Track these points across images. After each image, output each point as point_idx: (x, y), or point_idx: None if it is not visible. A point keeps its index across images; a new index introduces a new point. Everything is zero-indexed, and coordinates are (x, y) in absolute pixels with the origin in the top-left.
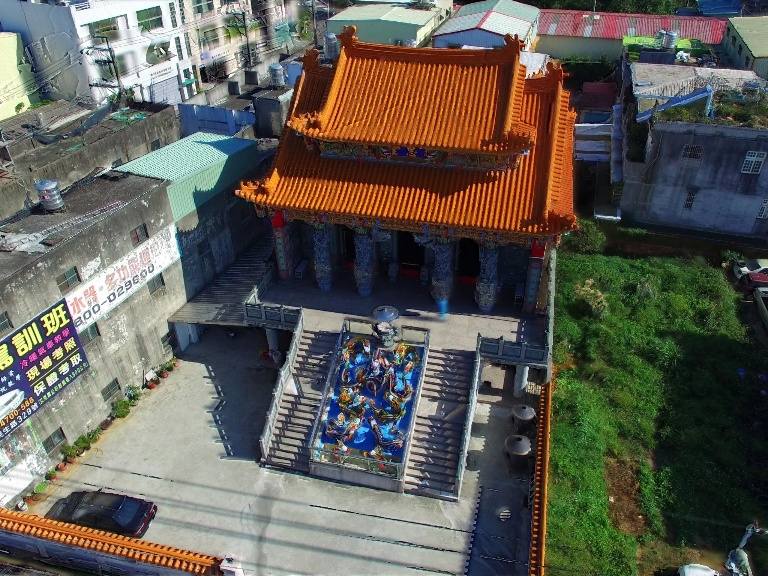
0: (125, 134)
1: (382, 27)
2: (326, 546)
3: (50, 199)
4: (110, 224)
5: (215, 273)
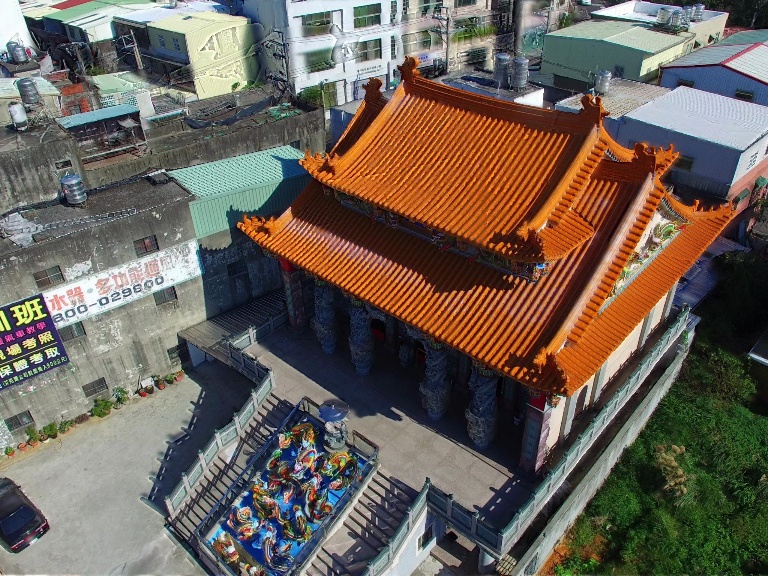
0: (261, 131)
1: (603, 49)
2: None
3: (70, 193)
4: (108, 230)
5: (251, 296)
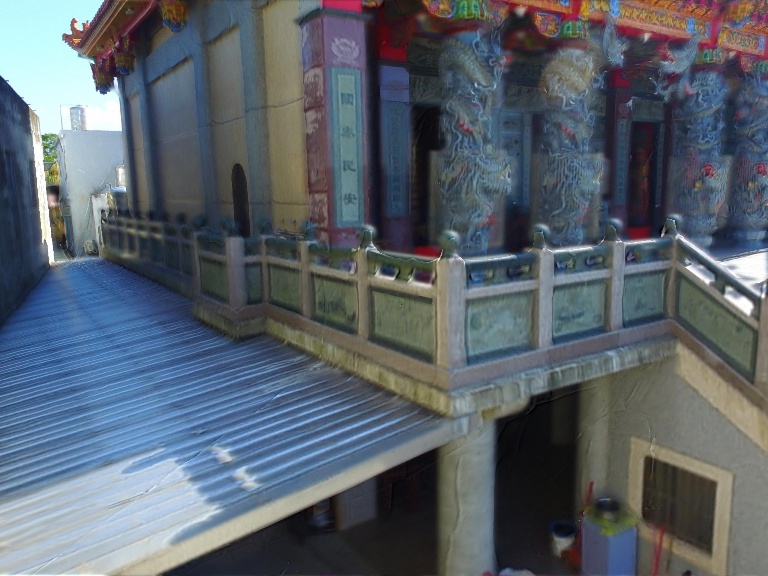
0: None
1: None
2: None
3: None
4: None
5: None
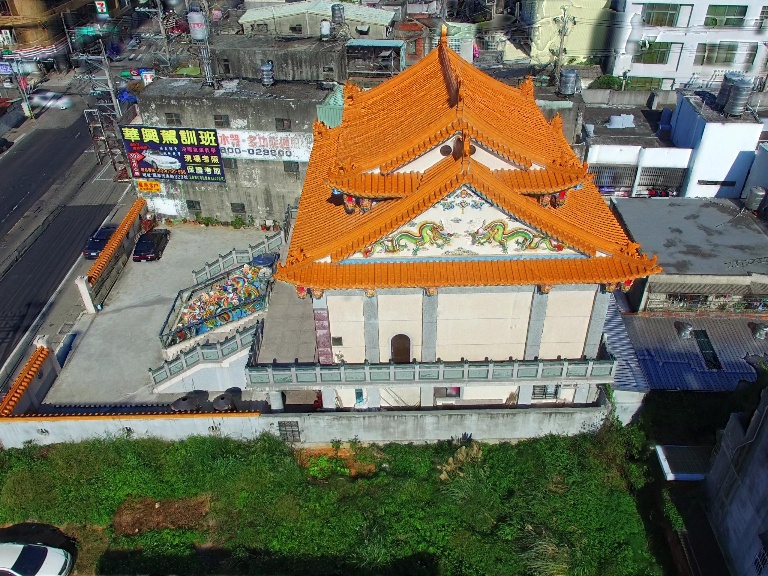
0: None
1: None
2: (123, 334)
3: None
4: (261, 104)
5: None
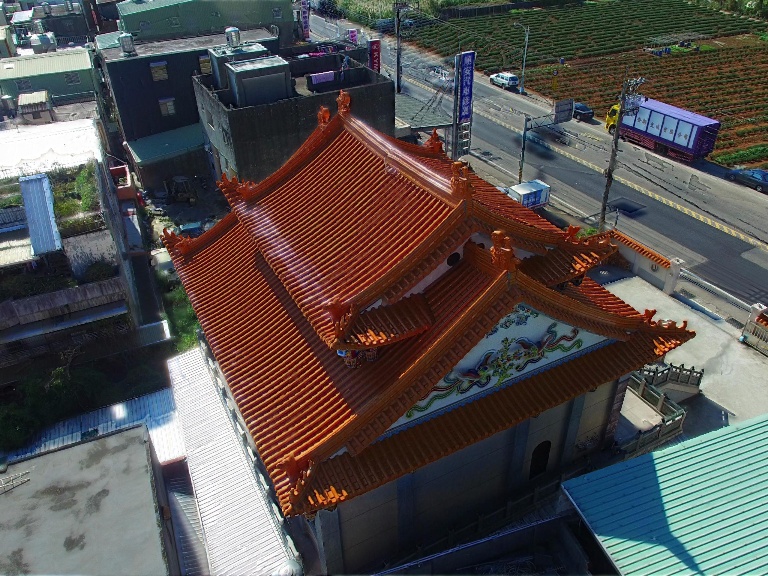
0: None
1: None
2: None
3: None
4: None
5: None
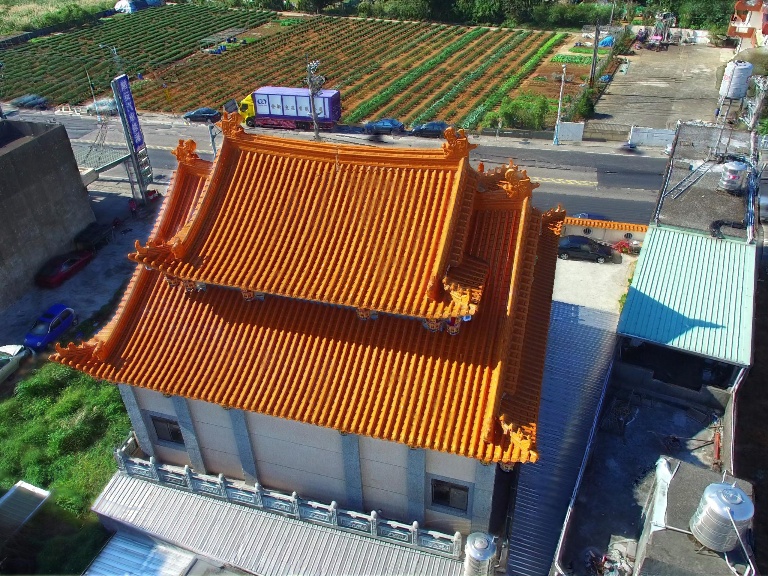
0: None
1: None
2: None
3: None
4: None
5: None
